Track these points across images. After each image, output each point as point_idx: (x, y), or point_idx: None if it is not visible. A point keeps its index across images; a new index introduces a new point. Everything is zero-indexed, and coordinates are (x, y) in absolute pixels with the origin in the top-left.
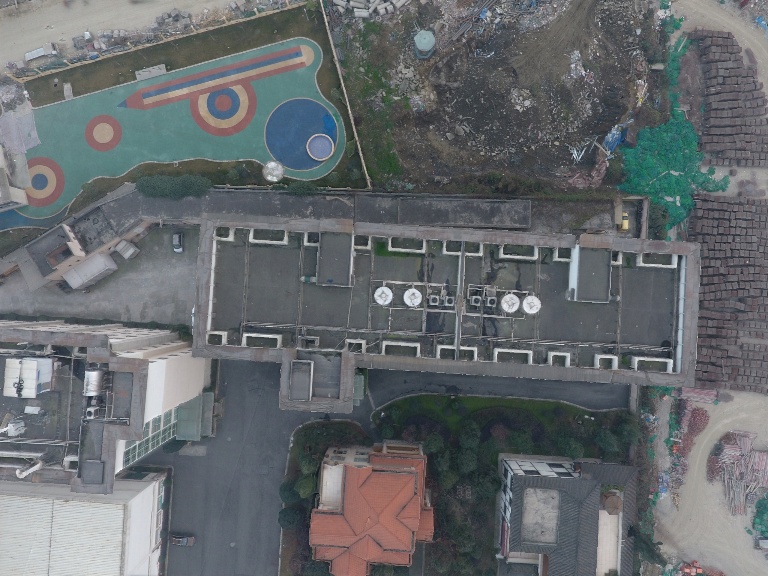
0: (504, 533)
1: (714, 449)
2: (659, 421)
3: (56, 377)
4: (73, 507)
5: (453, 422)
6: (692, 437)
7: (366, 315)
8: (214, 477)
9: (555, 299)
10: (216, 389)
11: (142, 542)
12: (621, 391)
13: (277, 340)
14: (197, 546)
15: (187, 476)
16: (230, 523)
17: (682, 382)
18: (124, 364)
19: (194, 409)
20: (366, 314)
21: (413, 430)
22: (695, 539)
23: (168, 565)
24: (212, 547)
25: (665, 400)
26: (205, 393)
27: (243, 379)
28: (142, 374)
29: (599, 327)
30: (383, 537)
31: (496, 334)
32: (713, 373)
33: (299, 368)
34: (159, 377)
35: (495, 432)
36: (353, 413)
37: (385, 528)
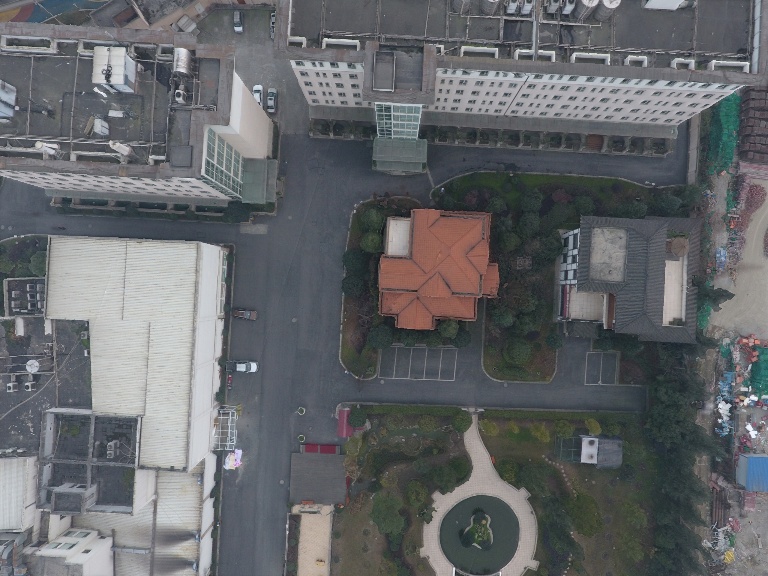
0: (566, 296)
1: None
2: (717, 198)
3: (139, 82)
4: (146, 248)
5: (512, 199)
6: (750, 213)
7: (443, 25)
8: (275, 255)
9: (631, 8)
10: None
11: (210, 298)
12: (679, 168)
13: (356, 48)
14: (259, 322)
15: (249, 254)
16: (292, 300)
17: (760, 80)
18: (211, 50)
19: (259, 173)
20: (443, 24)
21: (476, 194)
22: (752, 314)
23: (231, 341)
24: (274, 323)
25: (722, 177)
26: (269, 160)
27: (303, 158)
28: (229, 60)
29: (675, 36)
30: (453, 275)
31: (572, 43)
32: None
33: (382, 59)
34: (238, 92)
35: (557, 196)
36: (413, 191)
37: (456, 263)
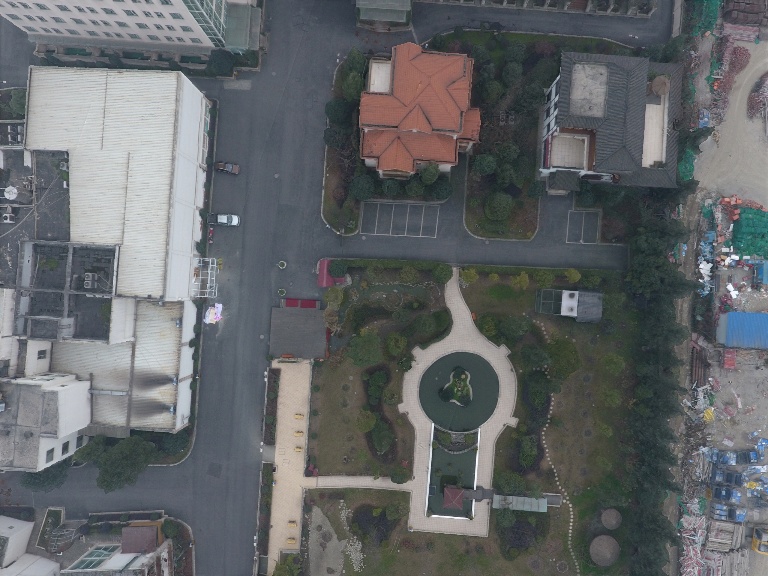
0: (548, 147)
1: (755, 87)
2: (700, 59)
3: None
4: (127, 77)
5: (496, 57)
6: (733, 74)
7: None
8: (259, 111)
9: None
10: (261, 23)
11: (191, 140)
12: (663, 29)
13: None
14: (241, 177)
15: (232, 109)
16: (274, 155)
17: None
18: None
19: (242, 18)
20: None
21: (459, 43)
22: (735, 175)
23: (213, 195)
24: (256, 178)
25: (707, 39)
26: (253, 8)
27: (288, 15)
28: None
29: None
30: (433, 108)
31: None
32: (756, 5)
33: None
34: None
35: (540, 46)
36: None
37: (436, 93)
